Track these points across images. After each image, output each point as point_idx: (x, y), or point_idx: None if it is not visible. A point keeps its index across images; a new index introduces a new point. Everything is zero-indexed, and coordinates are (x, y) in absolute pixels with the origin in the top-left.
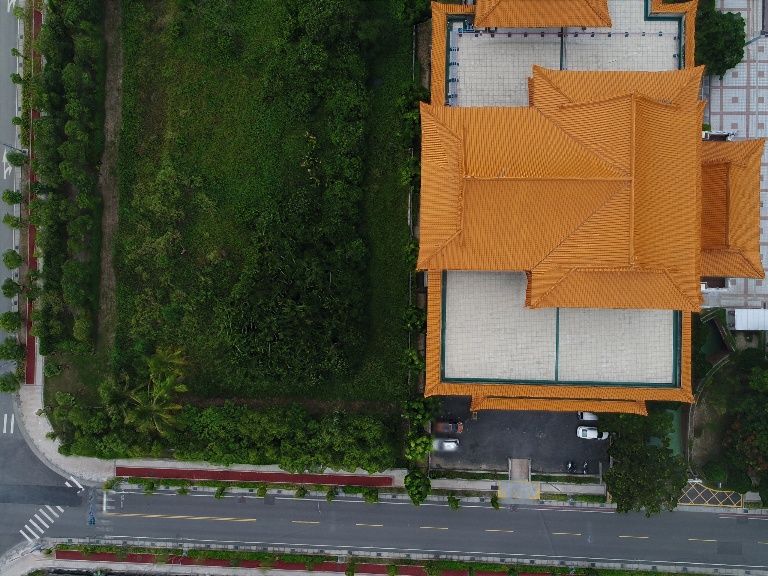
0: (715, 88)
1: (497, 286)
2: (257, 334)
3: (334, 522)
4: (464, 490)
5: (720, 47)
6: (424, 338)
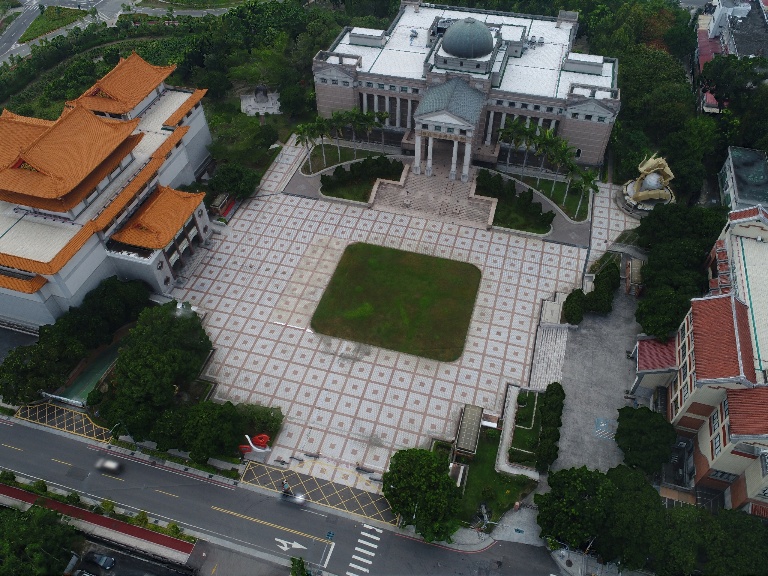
0: (242, 208)
1: None
2: None
3: None
4: None
5: (233, 176)
6: None
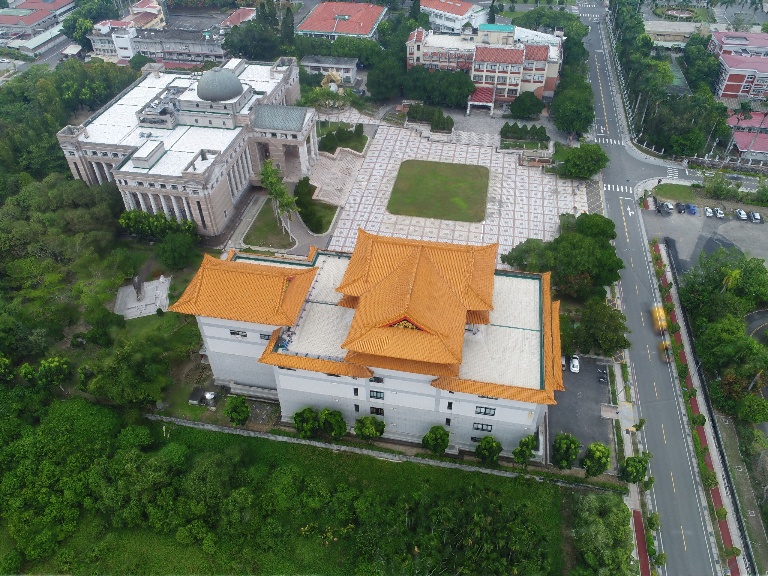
0: None
1: (472, 353)
2: (500, 573)
3: (689, 573)
4: (634, 454)
5: None
6: (503, 462)
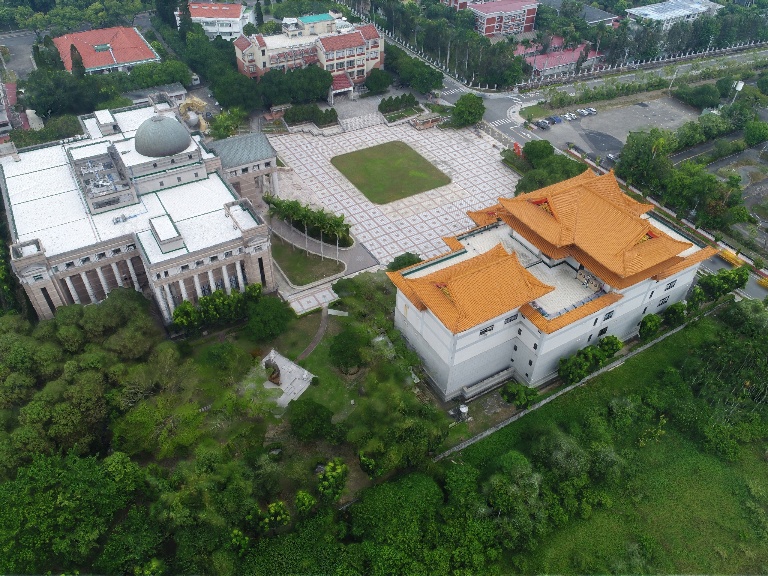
0: None
1: None
2: None
3: None
4: None
5: None
6: None
